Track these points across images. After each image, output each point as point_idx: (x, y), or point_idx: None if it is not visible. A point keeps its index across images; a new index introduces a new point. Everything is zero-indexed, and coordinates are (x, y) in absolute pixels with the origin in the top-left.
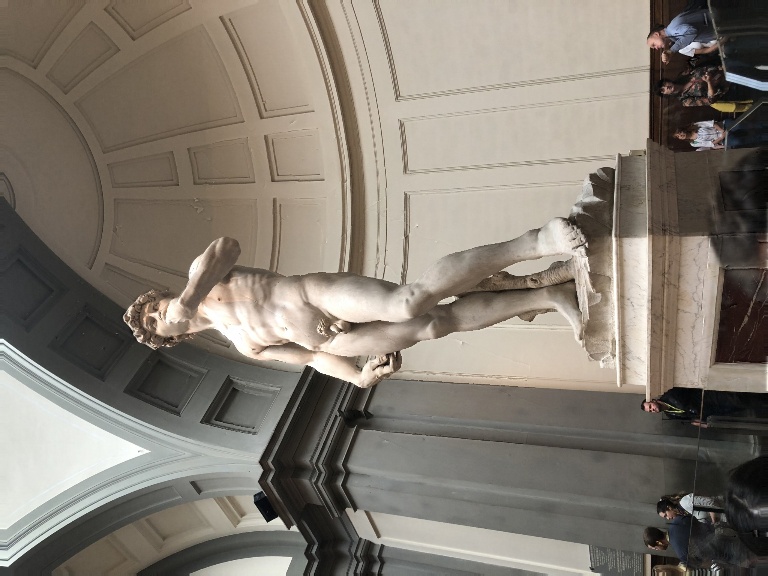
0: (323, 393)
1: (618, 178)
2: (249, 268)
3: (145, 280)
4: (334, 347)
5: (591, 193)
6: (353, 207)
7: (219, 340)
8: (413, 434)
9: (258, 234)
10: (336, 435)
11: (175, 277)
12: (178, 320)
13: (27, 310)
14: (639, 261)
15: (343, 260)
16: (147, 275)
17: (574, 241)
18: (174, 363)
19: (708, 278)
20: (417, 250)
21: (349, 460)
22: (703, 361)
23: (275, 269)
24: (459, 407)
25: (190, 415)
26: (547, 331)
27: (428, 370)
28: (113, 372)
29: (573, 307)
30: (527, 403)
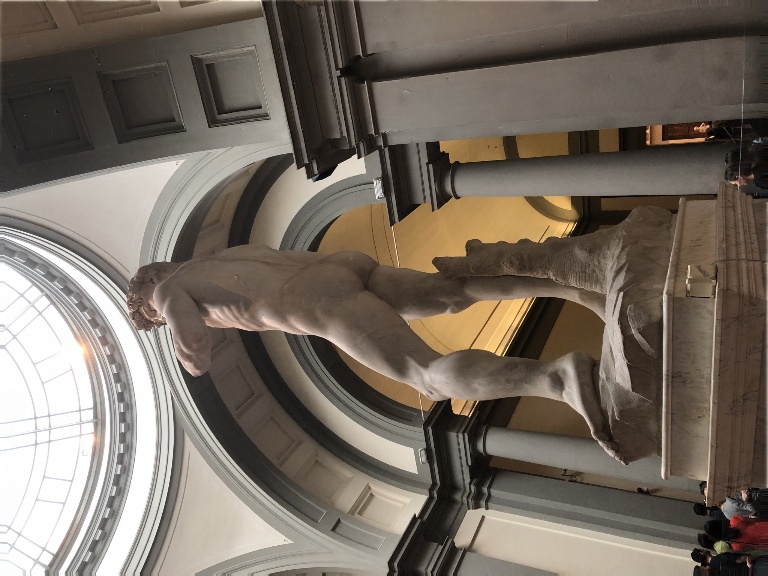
0: (305, 44)
1: (668, 361)
2: (215, 293)
3: None
4: None
5: (628, 386)
6: None
7: (141, 5)
8: (432, 74)
9: None
10: (351, 105)
11: None
12: None
13: None
14: None
15: None
16: None
17: None
18: (128, 73)
19: None
20: None
21: (379, 128)
22: None
23: None
24: (472, 19)
25: (194, 124)
26: None
27: None
28: (91, 132)
29: None
30: None
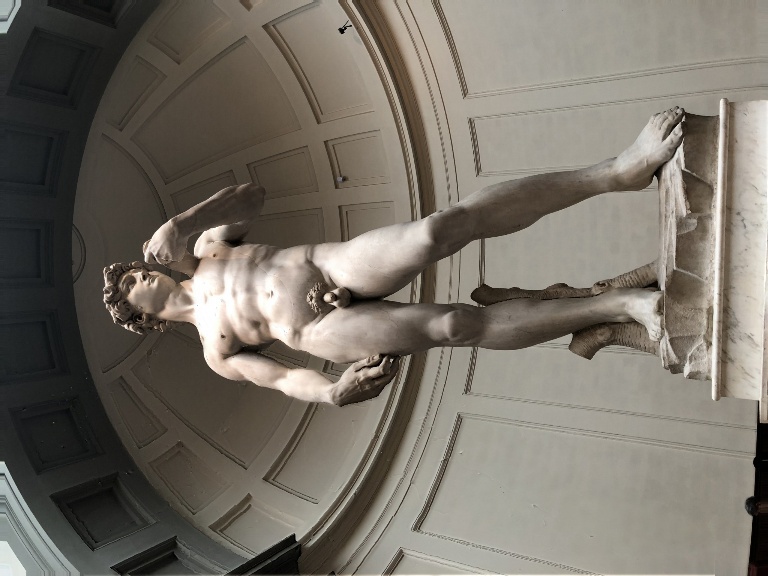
0: None
1: None
2: None
3: (148, 411)
4: (319, 329)
5: None
6: (397, 413)
7: (188, 504)
8: None
9: (286, 416)
10: None
11: (180, 423)
12: (159, 247)
13: (17, 369)
14: (757, 141)
15: (365, 461)
16: None
17: (666, 119)
18: (125, 499)
19: None
20: (453, 477)
21: None
22: None
23: (287, 457)
24: None
25: (105, 555)
26: None
27: None
28: (55, 471)
29: None
30: None
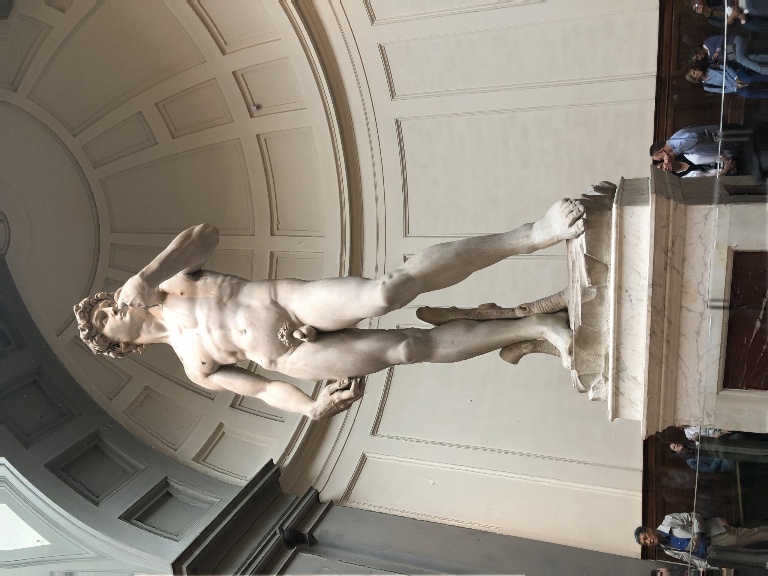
0: (267, 510)
1: (620, 184)
2: None
3: (110, 363)
4: (293, 360)
5: (592, 190)
6: None
7: (168, 442)
8: (360, 565)
9: None
10: (270, 552)
11: (142, 368)
12: (131, 299)
13: None
14: (640, 238)
15: None
16: (114, 360)
17: (571, 213)
18: (111, 452)
19: (715, 262)
20: (400, 383)
21: None
22: (709, 384)
23: None
24: (419, 544)
25: (109, 508)
26: (528, 482)
27: (390, 506)
28: (41, 442)
29: (563, 327)
30: (498, 549)
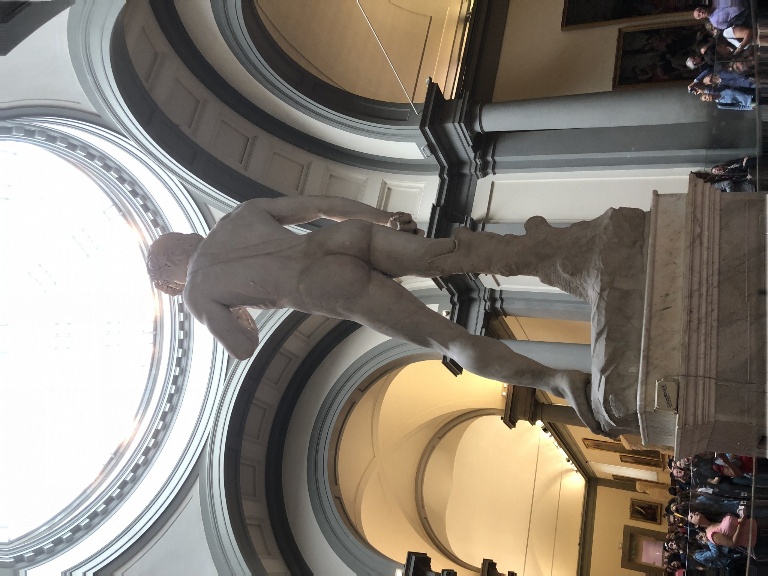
0: None
1: None
2: (240, 300)
3: None
4: None
5: None
6: None
7: None
8: None
9: None
10: None
11: None
12: None
13: None
14: None
15: None
16: None
17: None
18: None
19: None
20: None
21: None
22: None
23: None
24: None
25: None
26: None
27: None
28: None
29: None
30: None
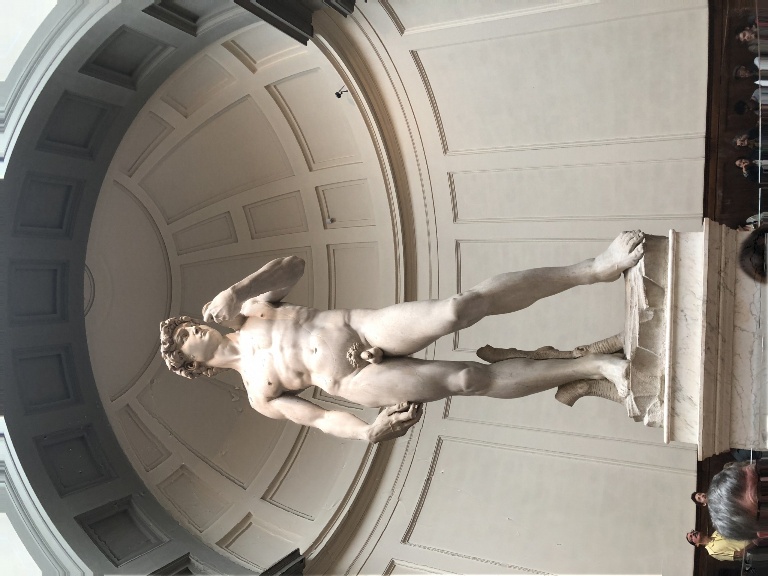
0: None
1: None
2: None
3: (154, 436)
4: (356, 381)
5: None
6: None
7: (194, 523)
8: None
9: (280, 440)
10: None
11: (182, 447)
12: (219, 310)
13: (37, 400)
14: (695, 261)
15: (357, 481)
16: None
17: (632, 239)
18: (139, 520)
19: (765, 284)
20: (436, 494)
21: None
22: (764, 405)
23: (282, 477)
24: None
25: (129, 571)
26: None
27: None
28: (76, 495)
29: (620, 359)
30: None
